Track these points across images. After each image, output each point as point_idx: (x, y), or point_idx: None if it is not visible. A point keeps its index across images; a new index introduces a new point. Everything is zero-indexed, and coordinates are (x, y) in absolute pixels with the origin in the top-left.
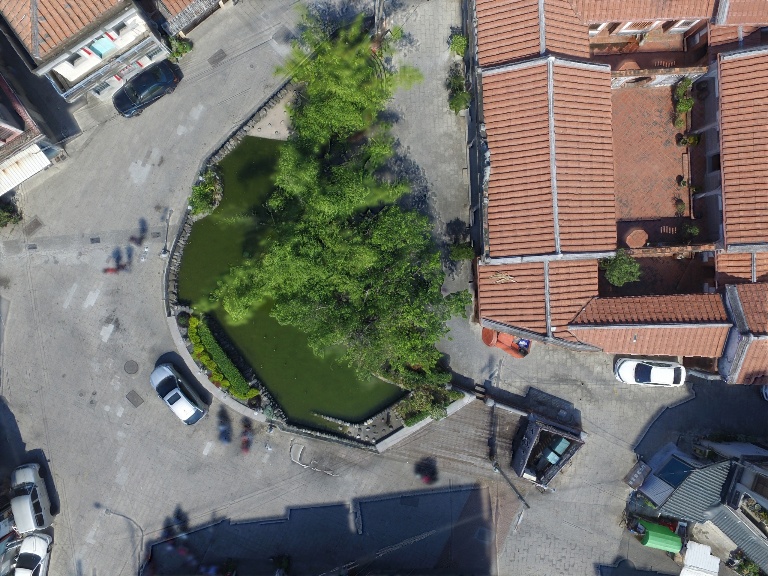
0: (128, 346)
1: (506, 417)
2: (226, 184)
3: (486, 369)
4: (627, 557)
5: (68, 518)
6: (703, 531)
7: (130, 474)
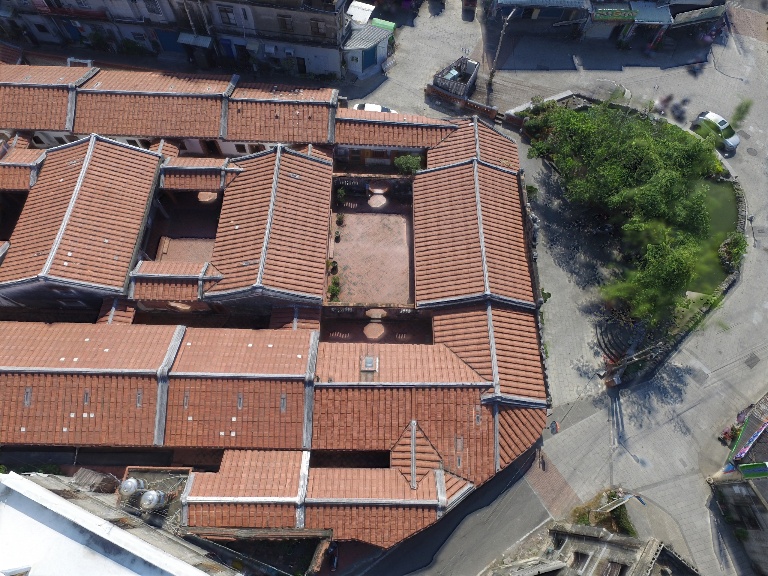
0: (759, 164)
1: (481, 103)
2: (717, 262)
3: None
4: None
5: (766, 79)
6: None
7: (733, 96)
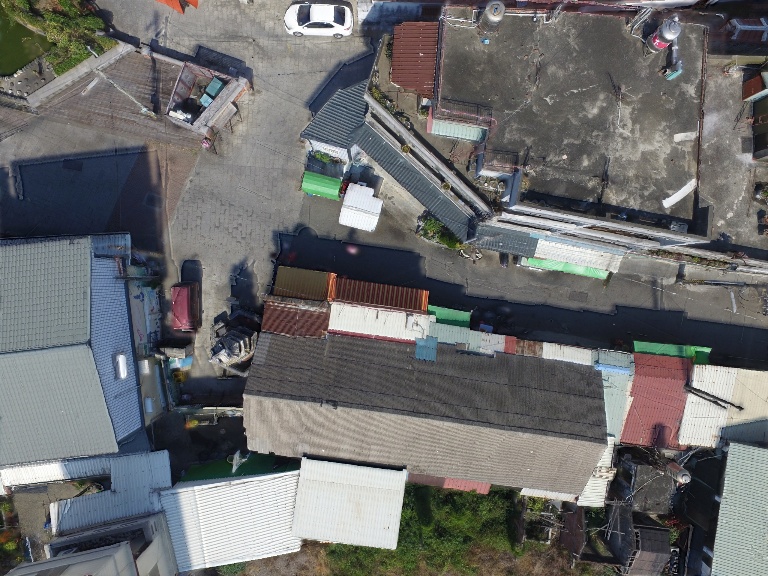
0: None
1: (169, 72)
2: None
3: (152, 27)
4: (308, 225)
5: None
6: (389, 196)
7: None
